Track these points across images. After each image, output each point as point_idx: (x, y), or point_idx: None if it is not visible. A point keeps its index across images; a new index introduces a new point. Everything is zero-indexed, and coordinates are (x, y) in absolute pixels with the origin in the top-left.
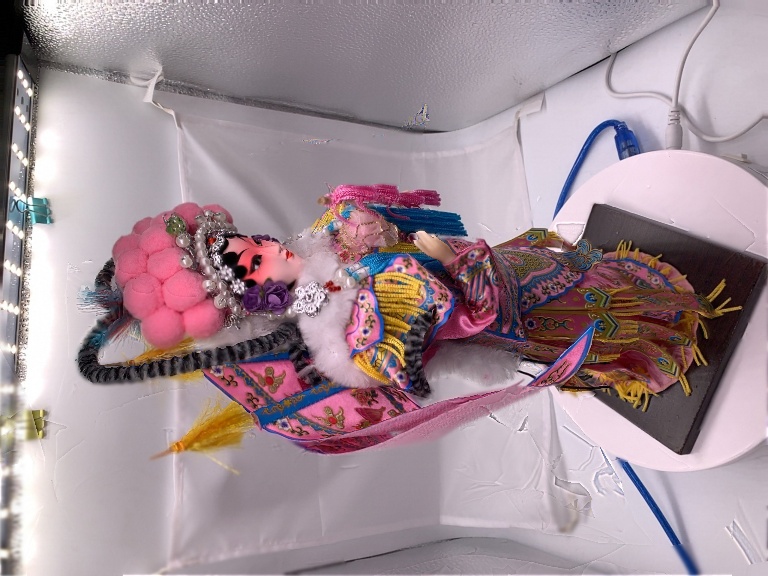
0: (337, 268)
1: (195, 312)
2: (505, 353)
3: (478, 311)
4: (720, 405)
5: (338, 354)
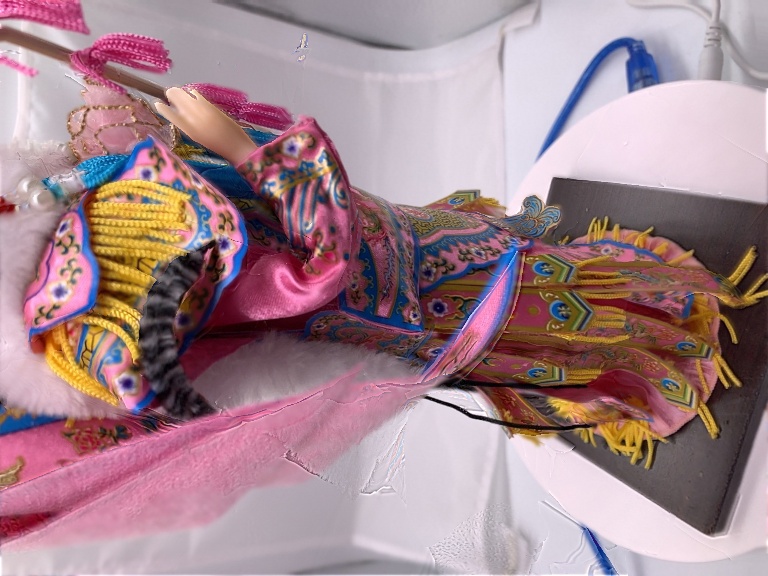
0: (23, 176)
1: None
2: (394, 359)
3: (310, 258)
4: (767, 452)
5: (7, 343)
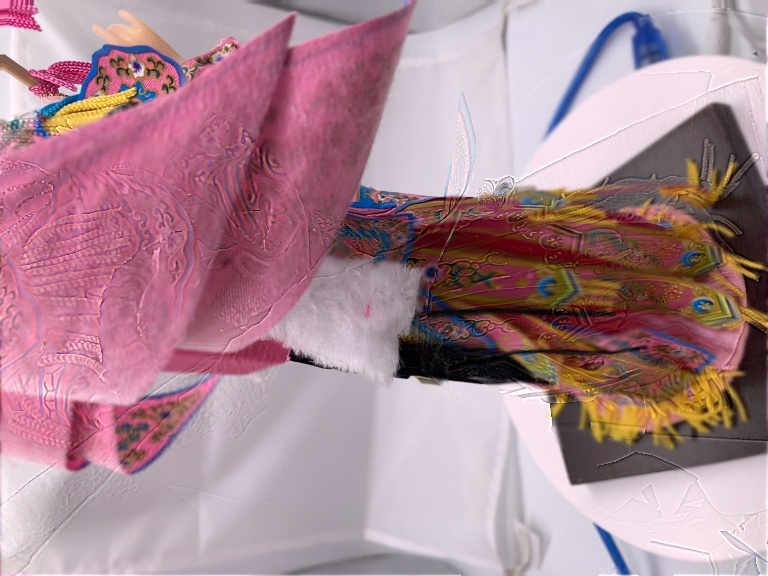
0: None
1: None
2: None
3: (266, 234)
4: None
5: None
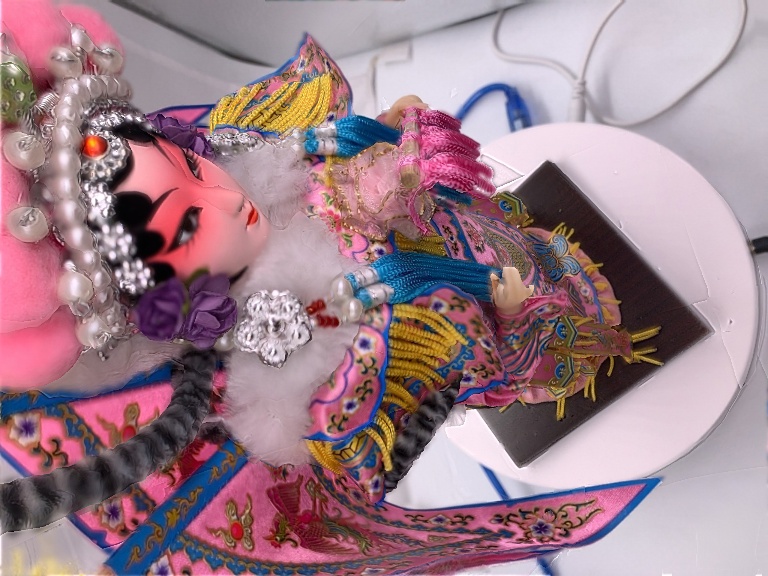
0: (338, 274)
1: (19, 345)
2: None
3: None
4: (578, 433)
5: (285, 427)
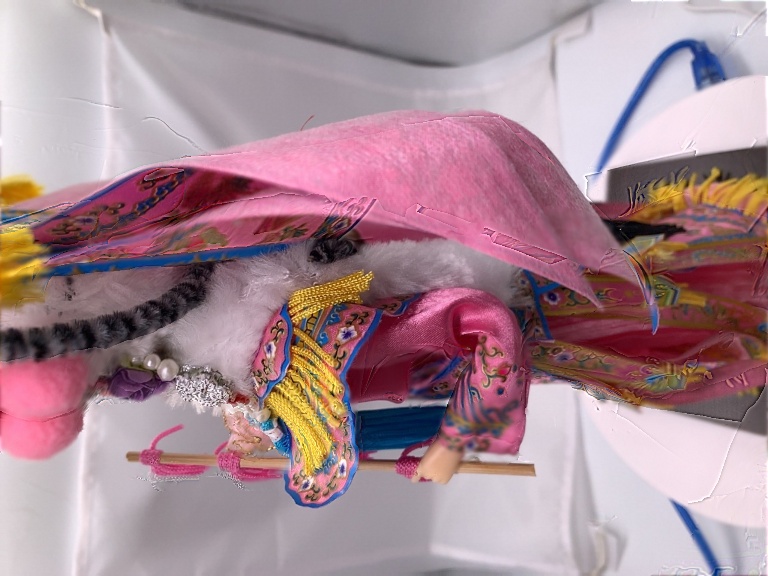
0: None
1: None
2: None
3: None
4: None
5: None
